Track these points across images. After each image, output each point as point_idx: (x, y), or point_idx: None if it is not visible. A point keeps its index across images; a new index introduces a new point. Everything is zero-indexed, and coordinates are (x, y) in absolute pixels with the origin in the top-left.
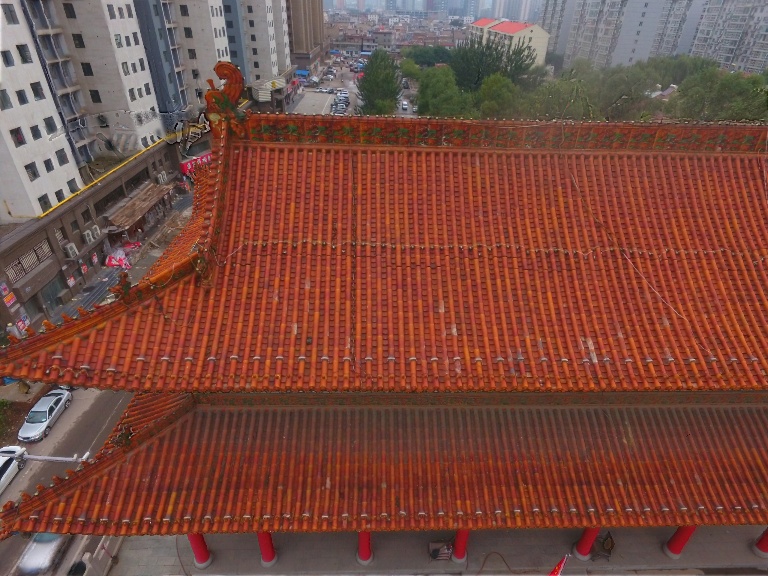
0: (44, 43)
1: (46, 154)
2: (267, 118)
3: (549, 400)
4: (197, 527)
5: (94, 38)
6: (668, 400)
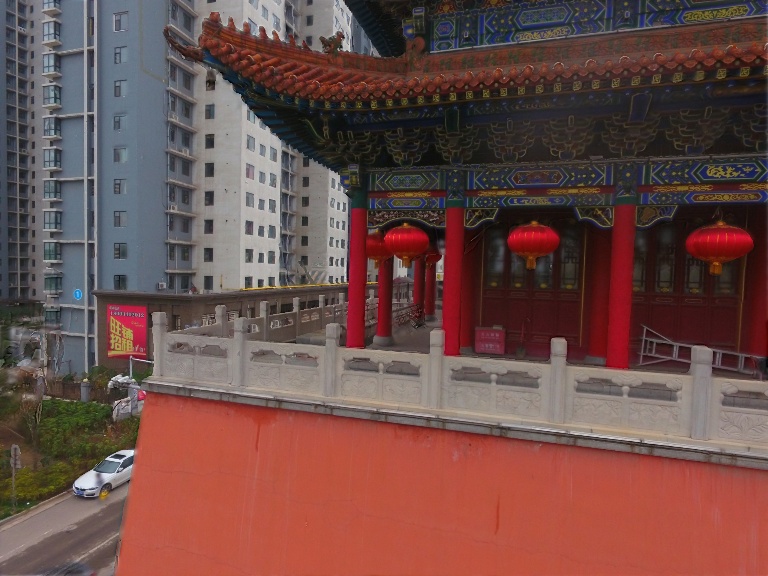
0: (283, 199)
1: (262, 249)
2: None
3: None
4: (401, 83)
5: (317, 199)
6: None
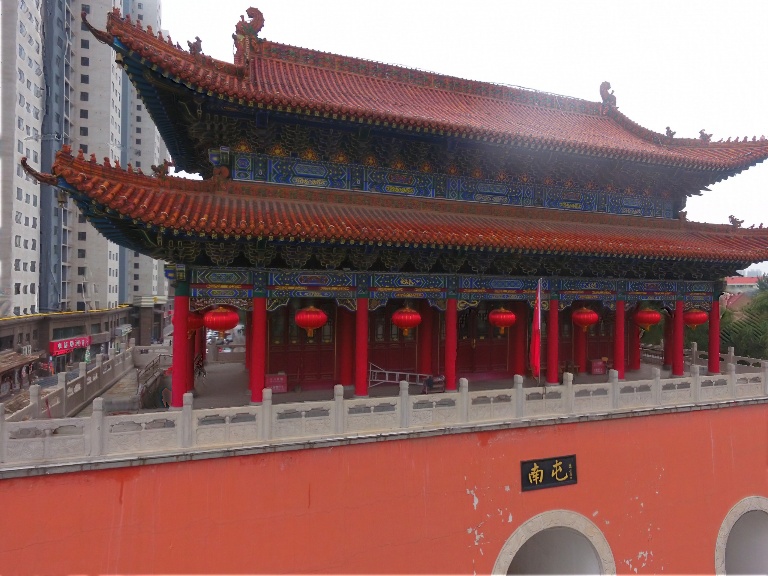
0: None
1: None
2: (276, 44)
3: (490, 211)
4: (235, 225)
5: None
6: (564, 218)
